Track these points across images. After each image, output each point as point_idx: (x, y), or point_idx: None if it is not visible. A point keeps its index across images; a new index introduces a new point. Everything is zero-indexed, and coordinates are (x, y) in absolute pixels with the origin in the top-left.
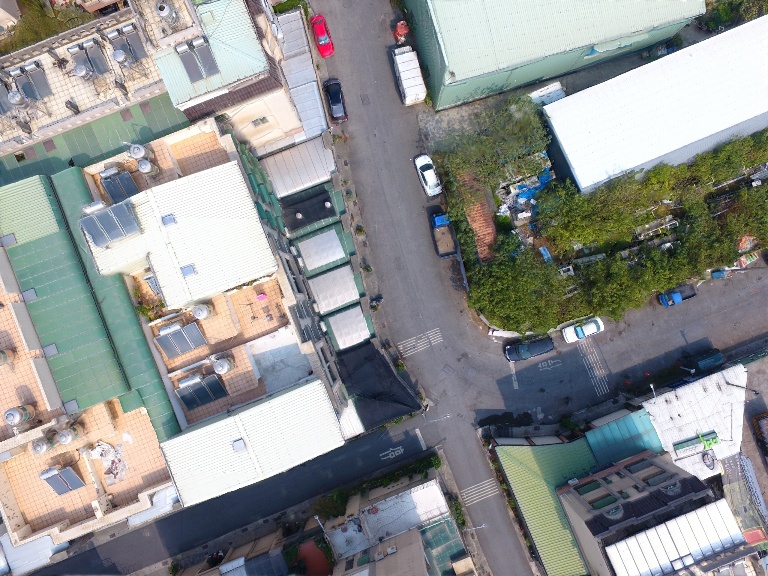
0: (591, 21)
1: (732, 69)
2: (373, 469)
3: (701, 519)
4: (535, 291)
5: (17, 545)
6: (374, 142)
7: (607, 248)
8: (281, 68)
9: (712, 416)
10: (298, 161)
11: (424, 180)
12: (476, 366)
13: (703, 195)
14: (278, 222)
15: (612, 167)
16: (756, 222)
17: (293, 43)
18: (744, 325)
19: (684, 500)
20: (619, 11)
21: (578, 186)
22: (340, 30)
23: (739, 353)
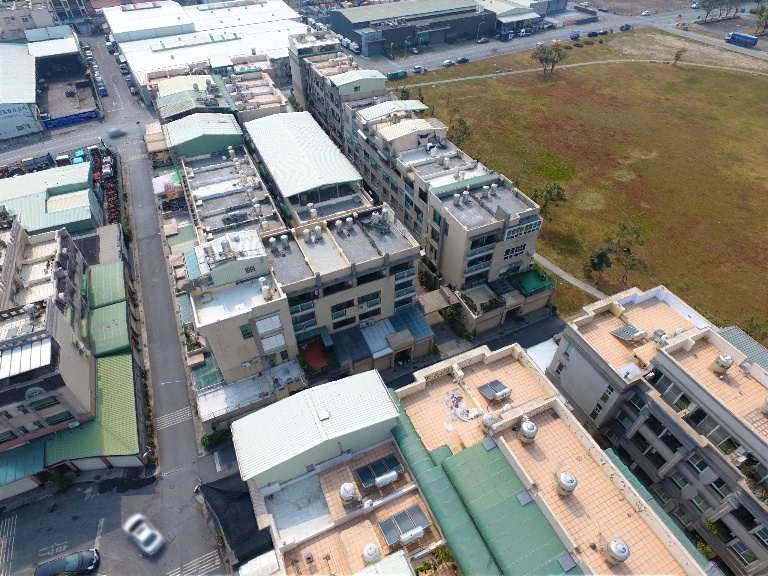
0: None
1: None
2: None
3: None
4: None
5: (515, 344)
6: None
7: None
8: None
9: None
10: None
11: None
12: (137, 543)
13: None
14: None
15: None
16: None
17: None
18: None
19: None
20: None
21: None
22: None
23: None
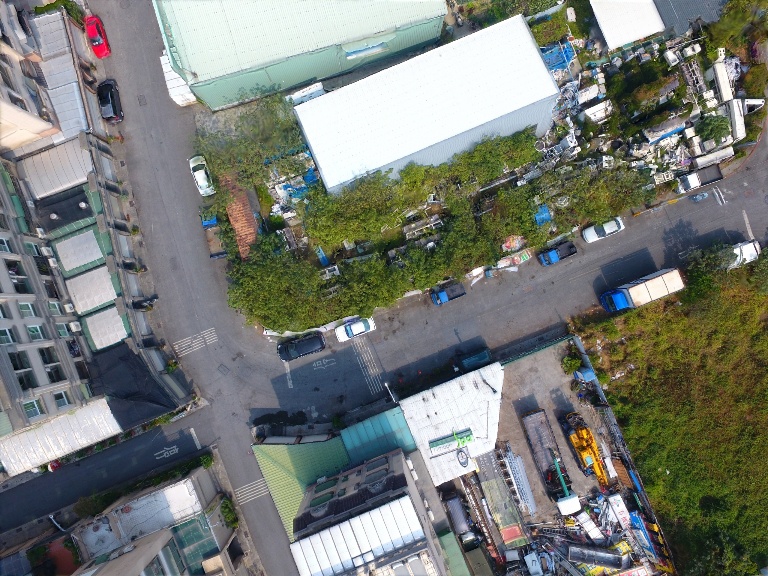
0: (332, 22)
1: (480, 69)
2: (148, 468)
3: (384, 516)
4: (286, 291)
5: None
6: (151, 143)
7: (381, 247)
8: (40, 69)
9: (468, 414)
10: (56, 162)
11: (196, 180)
12: (251, 365)
13: (463, 194)
14: (19, 223)
15: (359, 167)
16: (518, 221)
17: (53, 44)
18: (517, 323)
19: (381, 497)
20: (360, 12)
21: (325, 186)
22: (118, 31)
23: (512, 351)
